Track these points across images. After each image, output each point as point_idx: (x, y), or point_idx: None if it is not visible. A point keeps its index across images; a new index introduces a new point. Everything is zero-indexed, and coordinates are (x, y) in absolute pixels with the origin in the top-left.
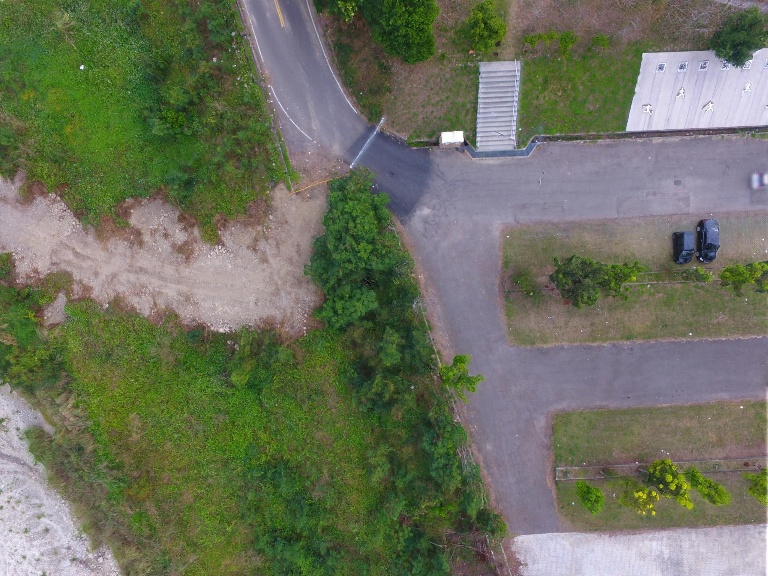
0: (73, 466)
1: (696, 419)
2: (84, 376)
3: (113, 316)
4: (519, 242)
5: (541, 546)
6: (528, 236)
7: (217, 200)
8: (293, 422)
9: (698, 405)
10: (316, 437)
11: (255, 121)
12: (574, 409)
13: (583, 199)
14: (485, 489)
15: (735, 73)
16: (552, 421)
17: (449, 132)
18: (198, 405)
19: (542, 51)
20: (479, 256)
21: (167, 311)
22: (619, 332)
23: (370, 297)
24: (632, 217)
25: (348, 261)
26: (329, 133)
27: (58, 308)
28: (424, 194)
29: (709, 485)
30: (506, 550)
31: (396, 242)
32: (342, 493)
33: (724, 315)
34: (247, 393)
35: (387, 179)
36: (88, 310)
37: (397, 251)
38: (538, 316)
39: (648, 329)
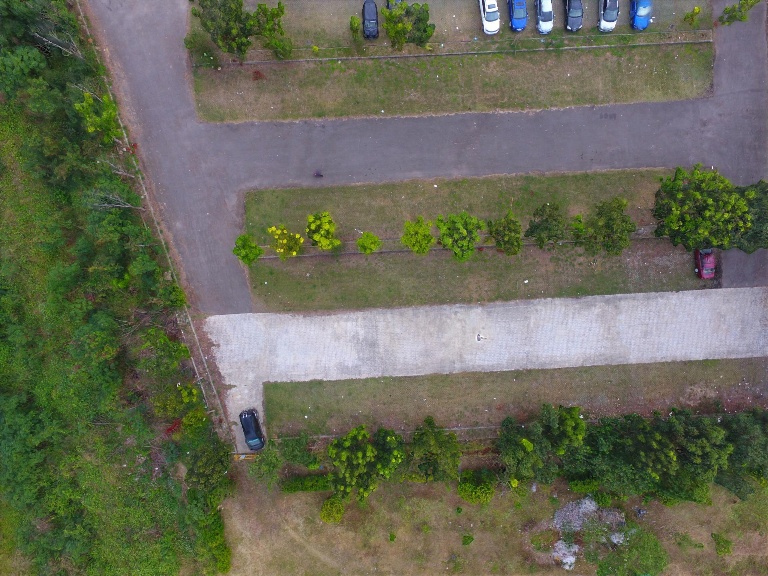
0: None
1: (390, 198)
2: None
3: None
4: None
5: (234, 327)
6: None
7: None
8: None
9: (392, 184)
10: (5, 217)
11: None
12: (266, 187)
13: None
14: (176, 268)
15: None
16: (244, 199)
17: None
18: None
19: None
20: (166, 30)
21: None
22: (310, 109)
23: (31, 53)
24: None
25: None
26: None
27: None
28: None
29: None
30: (198, 330)
31: None
32: (29, 272)
33: (416, 92)
34: None
35: None
36: None
37: None
38: (227, 92)
39: (340, 106)
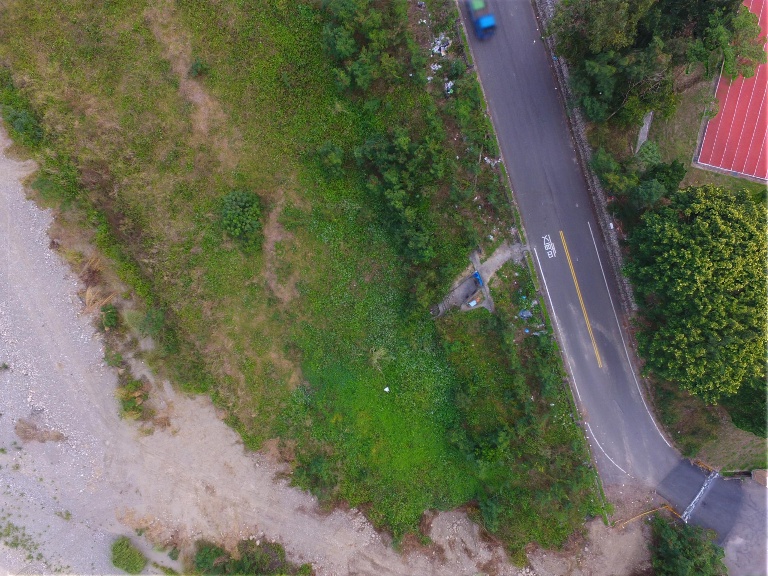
0: None
1: None
2: None
3: None
4: None
5: None
6: None
7: (531, 530)
8: None
9: None
10: None
11: (580, 466)
12: None
13: None
14: None
15: None
16: None
17: None
18: None
19: None
20: None
21: None
22: None
23: None
24: None
25: None
26: (643, 466)
27: None
28: (736, 524)
29: None
30: None
31: None
32: None
33: None
34: None
35: (699, 509)
36: None
37: None
38: None
39: None
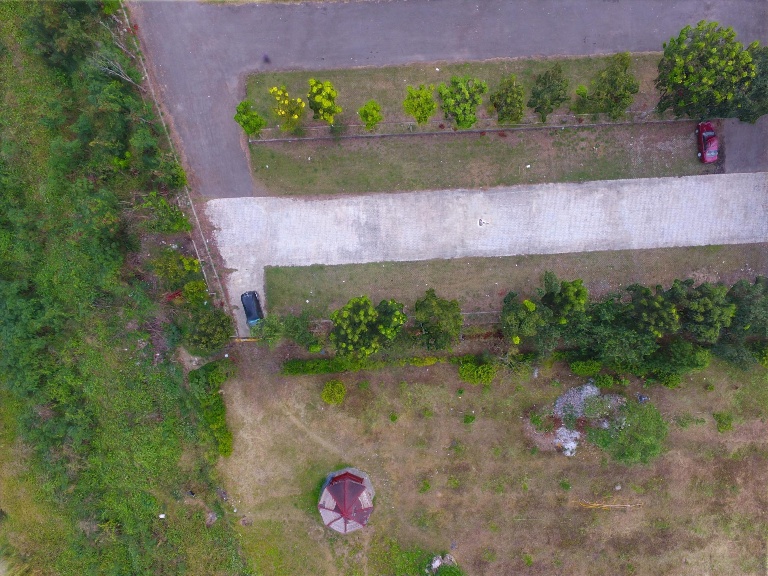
0: None
1: (392, 81)
2: None
3: None
4: None
5: (235, 210)
6: None
7: None
8: None
9: (393, 67)
10: (6, 100)
11: None
12: (267, 70)
13: None
14: (177, 151)
15: None
16: (245, 82)
17: None
18: None
19: None
20: None
21: None
22: None
23: None
24: None
25: None
26: None
27: None
28: None
29: None
30: (199, 214)
31: None
32: (30, 154)
33: None
34: None
35: None
36: None
37: None
38: None
39: None
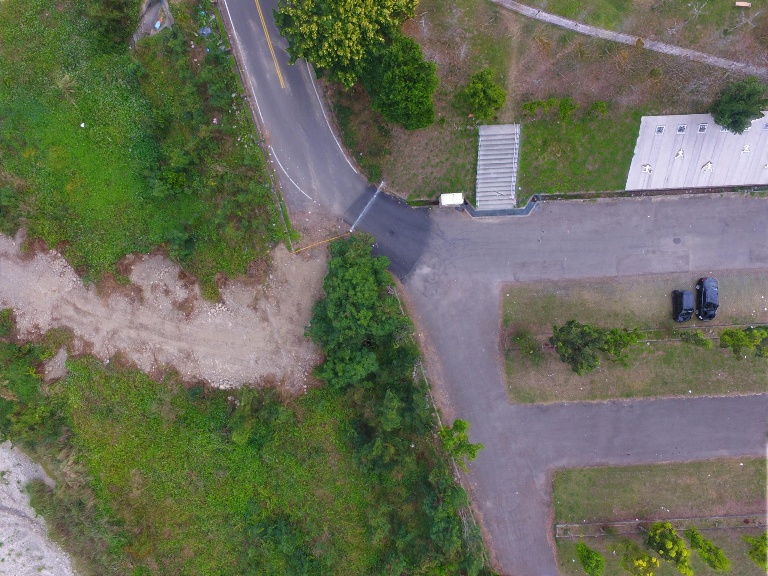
0: (74, 520)
1: (696, 476)
2: (85, 432)
3: (114, 372)
4: (519, 300)
5: None
6: (528, 294)
7: (217, 259)
8: (293, 479)
9: (698, 462)
10: (316, 494)
11: (255, 183)
12: (574, 466)
13: (583, 257)
14: (485, 546)
15: (734, 135)
16: (552, 478)
17: (449, 194)
18: (199, 461)
19: (541, 114)
20: (479, 314)
21: (168, 368)
22: (619, 389)
23: (370, 360)
24: (631, 275)
25: (348, 328)
26: (329, 193)
27: (59, 362)
28: (424, 253)
29: (709, 548)
30: None
31: (396, 306)
32: (342, 551)
33: (724, 372)
34: (247, 449)
35: (387, 238)
36: (89, 366)
37: (397, 315)
38: (538, 374)
39: (648, 386)
